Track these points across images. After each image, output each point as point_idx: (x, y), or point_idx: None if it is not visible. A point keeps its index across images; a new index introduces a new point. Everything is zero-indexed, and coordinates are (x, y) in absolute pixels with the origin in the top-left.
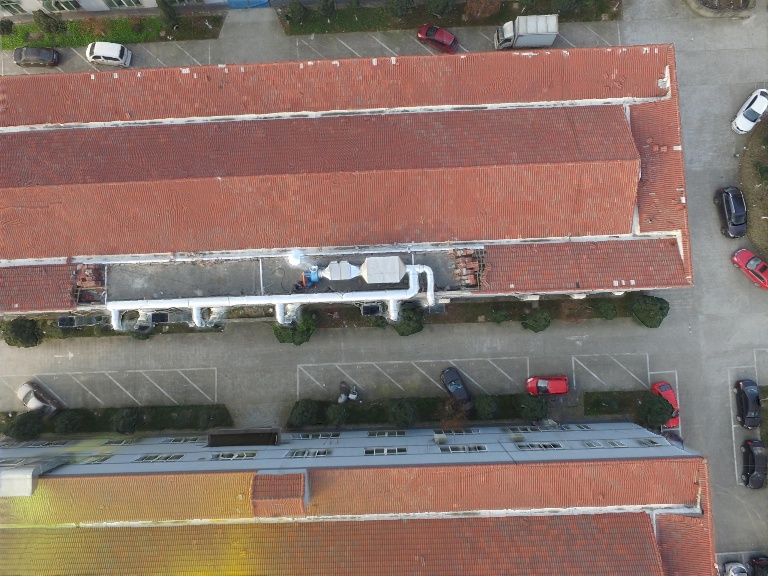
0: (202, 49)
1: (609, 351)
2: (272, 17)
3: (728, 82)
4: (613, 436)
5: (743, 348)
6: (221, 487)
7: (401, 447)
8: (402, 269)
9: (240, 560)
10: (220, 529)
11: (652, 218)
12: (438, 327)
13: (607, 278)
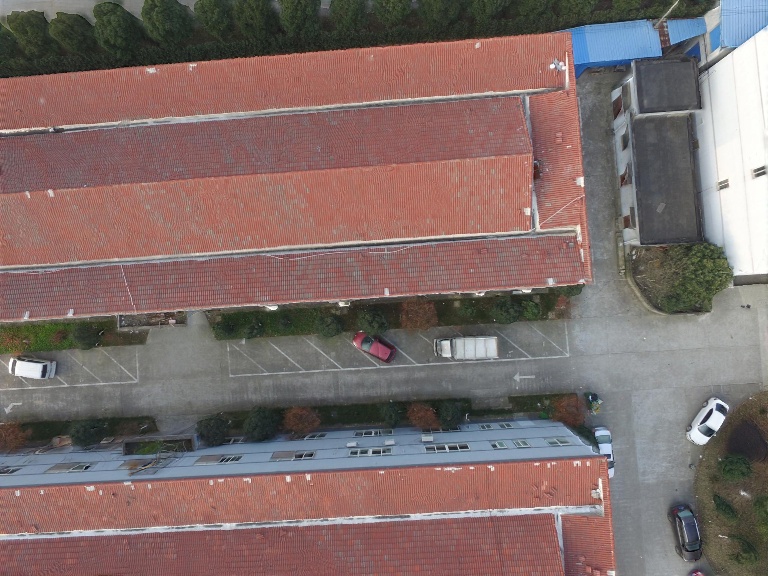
0: (129, 356)
1: None
2: (201, 320)
3: (683, 385)
4: None
5: None
6: None
7: None
8: None
9: None
10: None
11: None
12: None
13: None
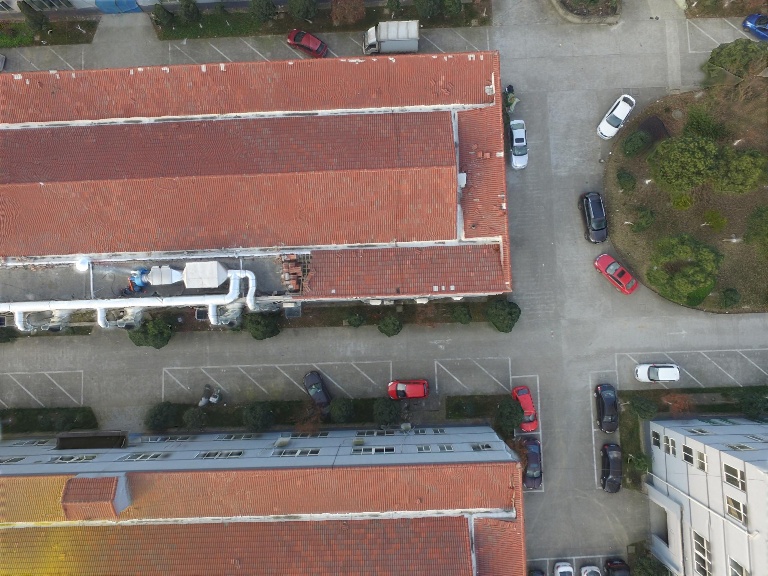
0: (76, 54)
1: (471, 355)
2: (145, 22)
3: (595, 88)
4: (449, 440)
5: (604, 352)
6: (40, 490)
7: (237, 451)
8: (222, 274)
9: (59, 563)
10: (43, 532)
11: (476, 224)
12: (303, 331)
13: (428, 283)
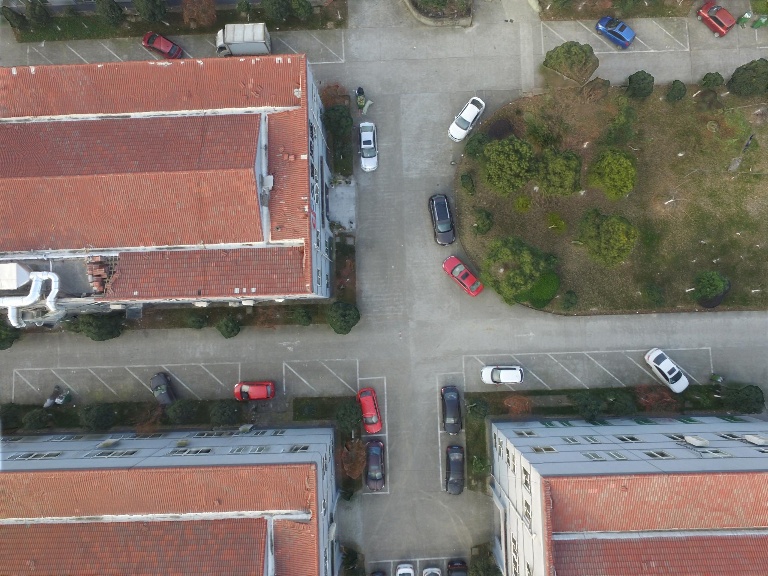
0: None
1: (319, 357)
2: (4, 24)
3: (448, 90)
4: (269, 442)
5: (452, 354)
6: None
7: (55, 452)
8: (23, 276)
9: None
10: None
11: (281, 226)
12: (153, 332)
13: (230, 286)
